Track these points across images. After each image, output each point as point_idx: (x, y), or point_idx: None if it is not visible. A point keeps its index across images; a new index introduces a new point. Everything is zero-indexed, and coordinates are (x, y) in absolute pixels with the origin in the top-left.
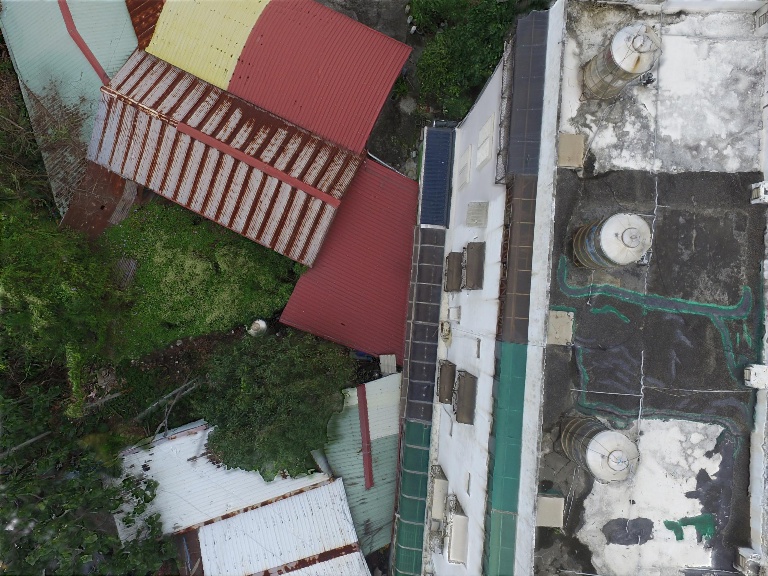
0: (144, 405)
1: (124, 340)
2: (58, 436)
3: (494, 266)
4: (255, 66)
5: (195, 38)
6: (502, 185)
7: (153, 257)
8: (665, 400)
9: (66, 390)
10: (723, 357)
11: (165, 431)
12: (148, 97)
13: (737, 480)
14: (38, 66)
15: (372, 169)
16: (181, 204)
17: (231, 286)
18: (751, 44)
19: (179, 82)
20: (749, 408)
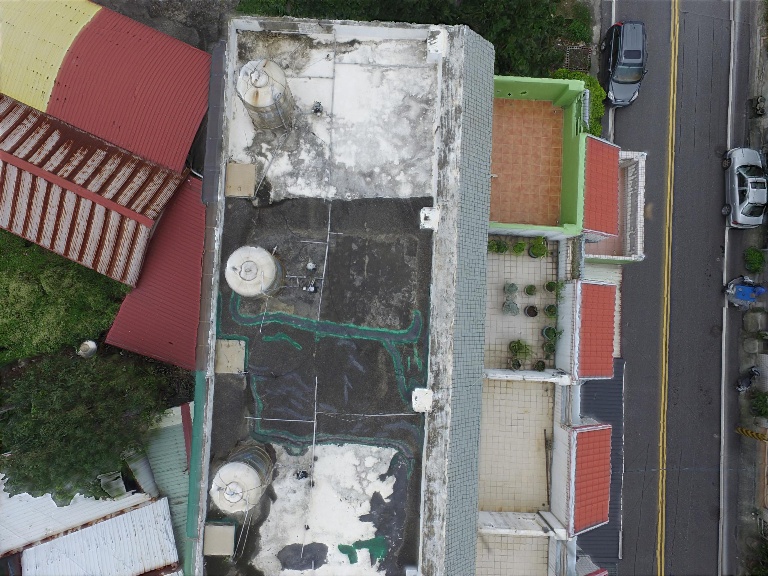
0: None
1: None
2: None
3: None
4: (72, 88)
5: (10, 61)
6: None
7: None
8: (338, 425)
9: None
10: (394, 381)
11: None
12: None
13: (410, 502)
14: None
15: (197, 187)
16: (2, 227)
17: (57, 308)
18: (423, 71)
19: None
20: (420, 431)
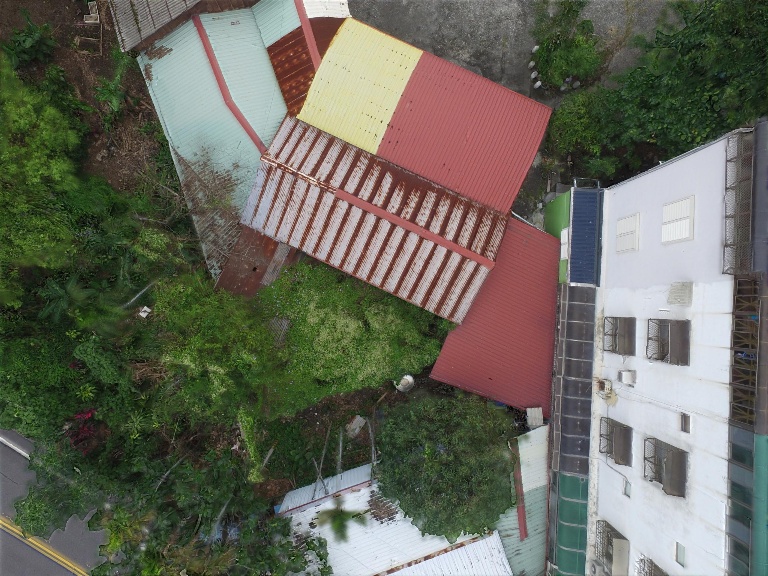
0: (289, 457)
1: (278, 398)
2: (238, 500)
3: (715, 350)
4: (404, 131)
5: (346, 105)
6: (729, 275)
7: (306, 317)
8: None
9: (211, 444)
10: None
11: (325, 487)
12: (305, 164)
13: None
14: (191, 134)
15: (515, 227)
16: (333, 266)
17: (381, 343)
18: None
19: (330, 148)
20: None
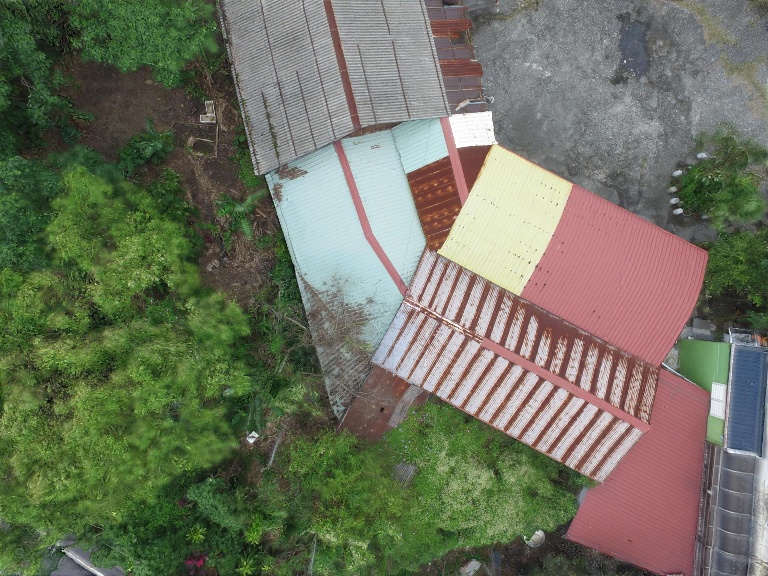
0: None
1: (400, 549)
2: None
3: None
4: (554, 274)
5: (492, 243)
6: None
7: (435, 465)
8: None
9: None
10: None
11: None
12: (449, 308)
13: None
14: (321, 262)
15: (663, 378)
16: (469, 413)
17: (514, 496)
18: None
19: (473, 287)
20: None
